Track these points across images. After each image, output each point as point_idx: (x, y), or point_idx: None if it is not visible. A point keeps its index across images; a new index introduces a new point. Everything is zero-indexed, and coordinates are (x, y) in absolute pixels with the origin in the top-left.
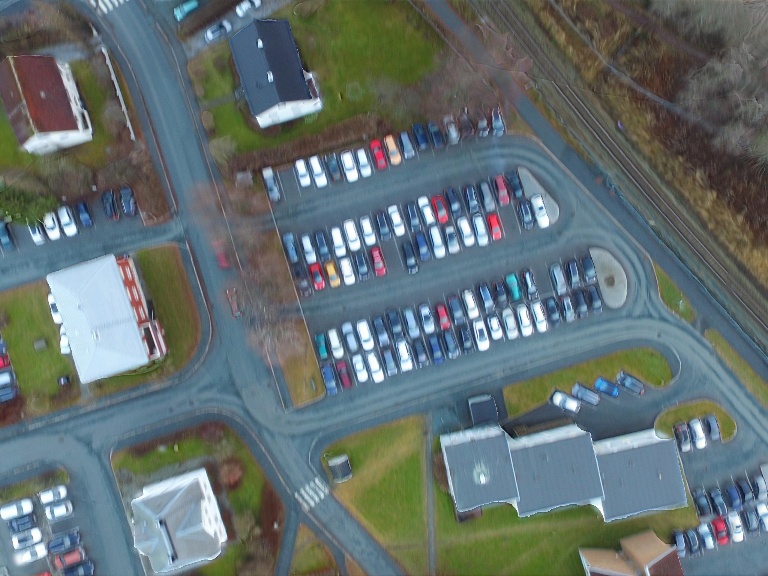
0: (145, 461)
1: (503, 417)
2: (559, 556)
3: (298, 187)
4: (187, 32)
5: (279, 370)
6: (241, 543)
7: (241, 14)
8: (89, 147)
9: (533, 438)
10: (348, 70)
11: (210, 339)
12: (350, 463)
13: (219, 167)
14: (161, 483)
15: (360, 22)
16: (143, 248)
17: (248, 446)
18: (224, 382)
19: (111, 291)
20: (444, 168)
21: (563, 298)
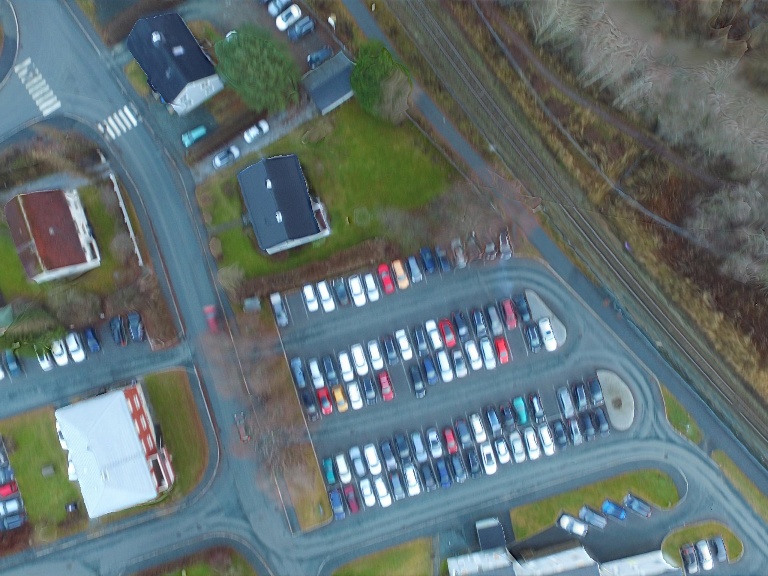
0: None
1: (510, 540)
2: None
3: (306, 311)
4: (195, 158)
5: (287, 494)
6: None
7: (249, 140)
8: (97, 273)
9: (541, 564)
10: (356, 194)
11: (218, 463)
12: None
13: (227, 293)
14: None
15: (368, 146)
16: (151, 373)
17: (256, 570)
18: (232, 506)
19: (120, 428)
20: (452, 291)
21: (570, 422)
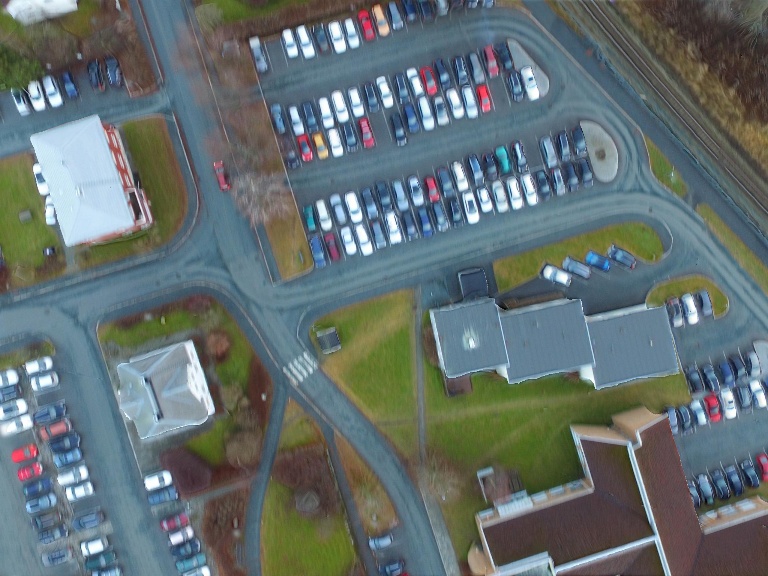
0: (132, 333)
1: (493, 291)
2: (550, 433)
3: (285, 58)
4: None
5: (267, 243)
6: (229, 416)
7: None
8: (74, 17)
9: (523, 309)
10: None
11: (197, 212)
12: (339, 337)
13: (205, 36)
14: (148, 353)
15: None
16: (129, 120)
17: (236, 319)
18: (211, 255)
19: (96, 151)
20: (433, 40)
21: (553, 170)
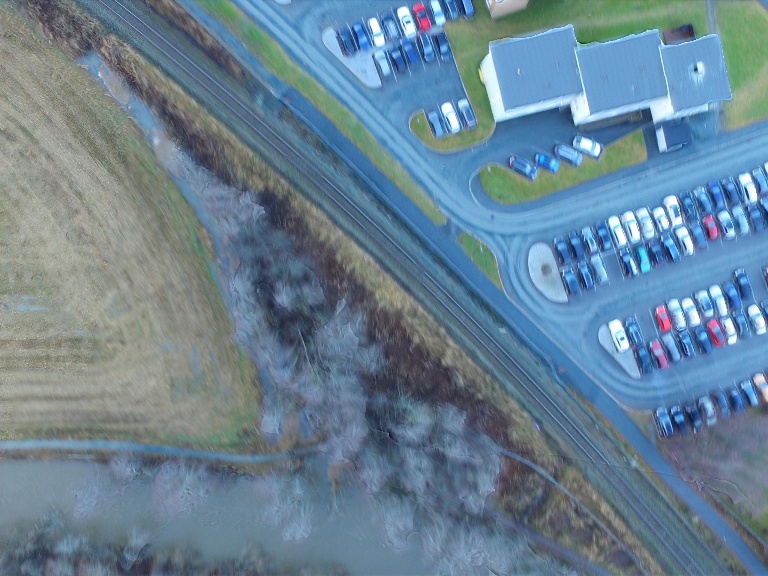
0: None
1: (648, 130)
2: None
3: None
4: None
5: None
6: None
7: None
8: None
9: None
10: None
11: None
12: None
13: None
14: None
15: None
16: None
17: None
18: None
19: None
20: (711, 373)
21: None
